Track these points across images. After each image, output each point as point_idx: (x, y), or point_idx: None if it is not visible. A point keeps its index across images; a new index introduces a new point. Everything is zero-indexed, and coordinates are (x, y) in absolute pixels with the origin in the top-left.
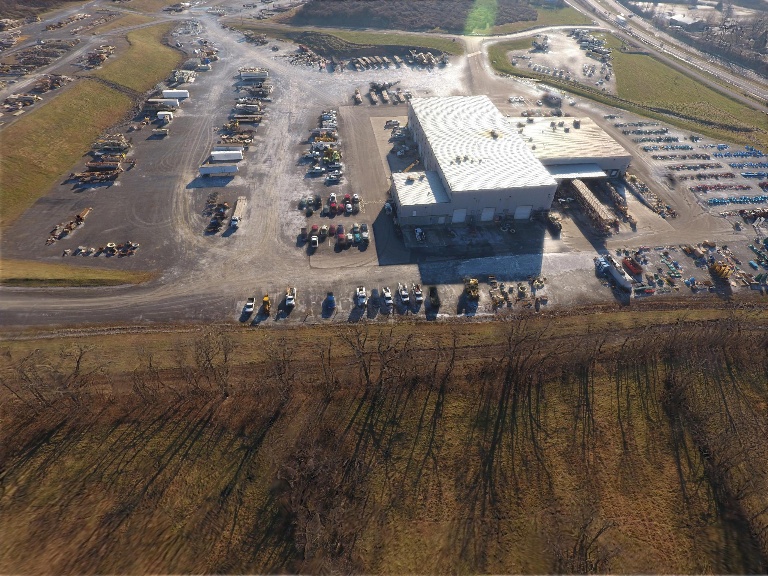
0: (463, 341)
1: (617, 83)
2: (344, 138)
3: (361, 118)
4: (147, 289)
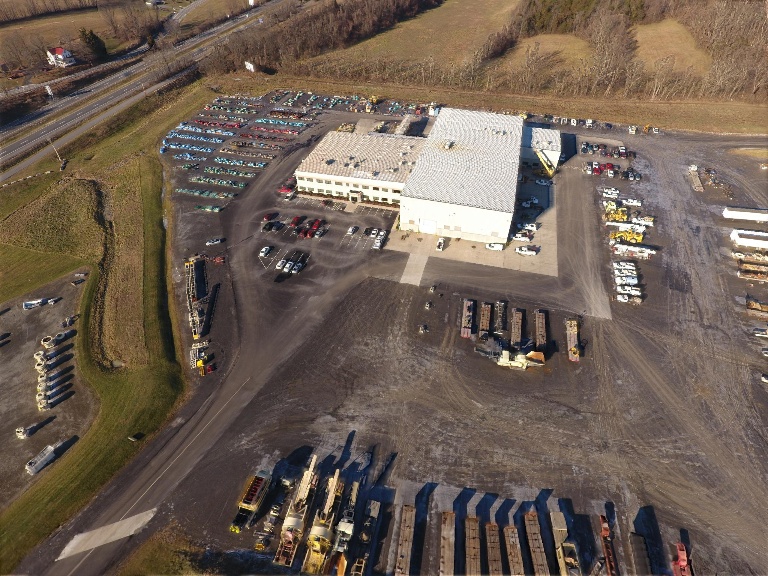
0: (541, 102)
1: (8, 299)
2: (601, 243)
3: (573, 277)
4: (728, 146)
